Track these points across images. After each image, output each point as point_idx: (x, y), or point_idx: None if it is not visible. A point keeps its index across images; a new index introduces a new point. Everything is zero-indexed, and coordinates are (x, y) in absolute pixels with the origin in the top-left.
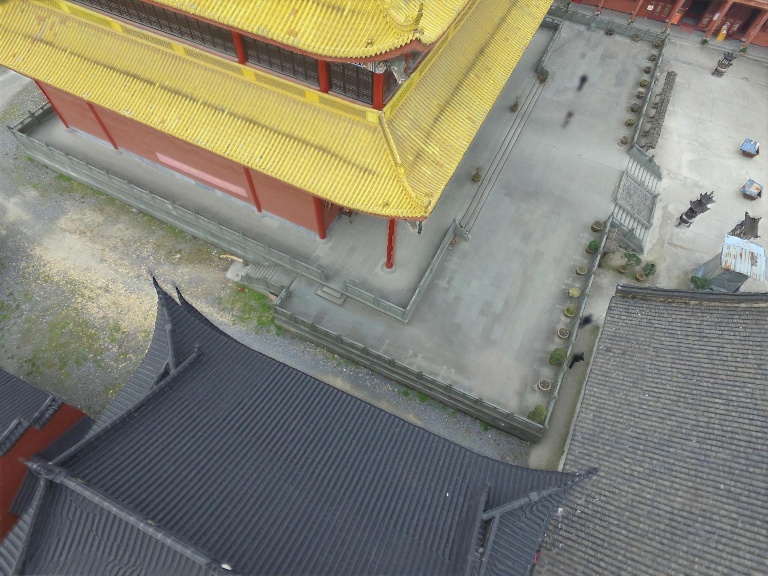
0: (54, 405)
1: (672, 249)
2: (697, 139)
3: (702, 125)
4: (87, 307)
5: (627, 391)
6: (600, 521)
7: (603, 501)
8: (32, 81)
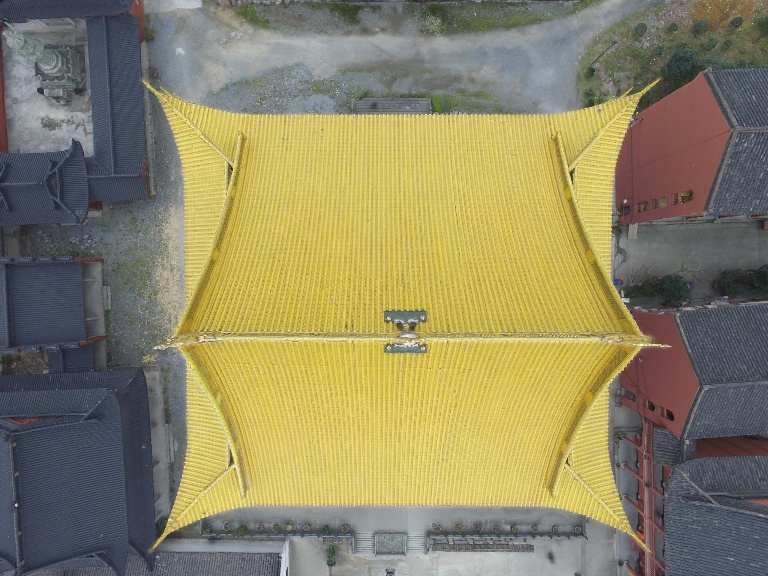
0: (74, 347)
1: (366, 570)
2: (483, 572)
3: (502, 573)
4: (158, 268)
5: (220, 574)
6: (157, 575)
7: (165, 574)
8: (293, 67)
